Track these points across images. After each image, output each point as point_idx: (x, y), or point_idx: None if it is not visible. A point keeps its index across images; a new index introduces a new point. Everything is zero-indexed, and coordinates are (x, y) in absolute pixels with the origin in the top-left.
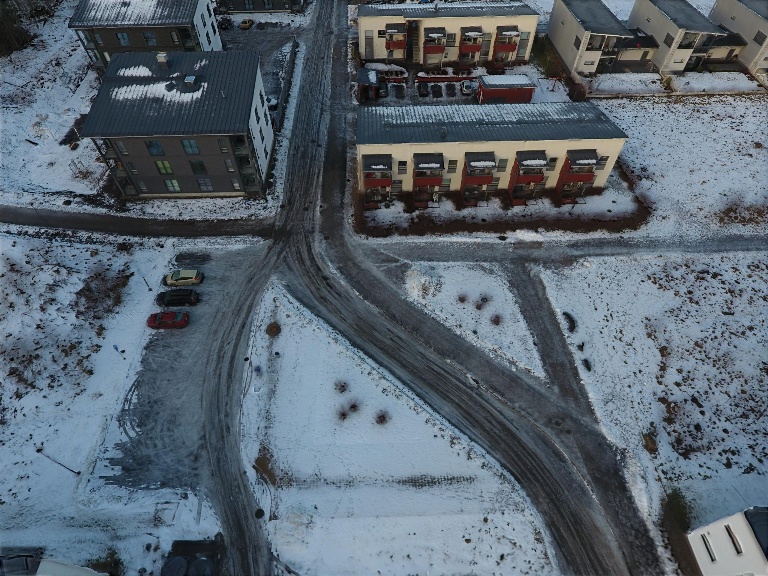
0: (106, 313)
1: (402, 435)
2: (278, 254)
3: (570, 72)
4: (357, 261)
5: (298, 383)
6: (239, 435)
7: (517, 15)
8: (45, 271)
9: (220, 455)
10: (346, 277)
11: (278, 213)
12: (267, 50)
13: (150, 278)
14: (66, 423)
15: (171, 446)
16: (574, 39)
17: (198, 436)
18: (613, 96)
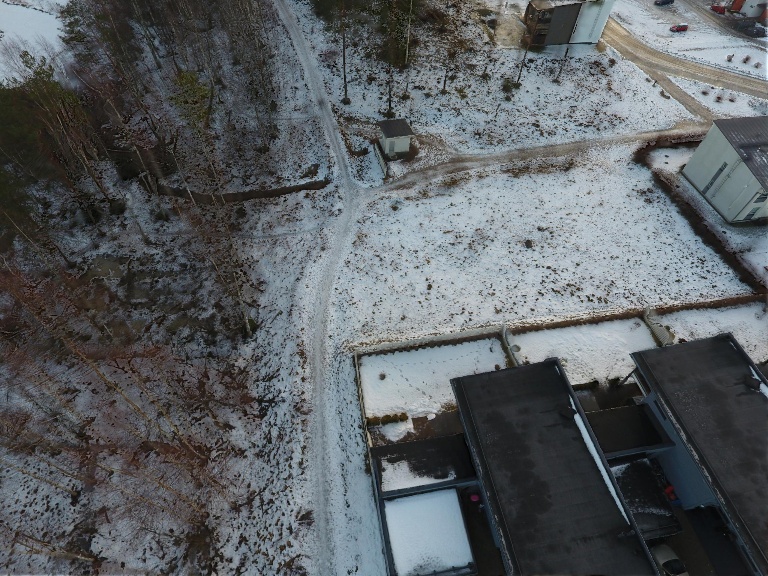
0: None
1: None
2: None
3: None
4: None
5: None
6: None
7: None
8: None
9: None
10: None
11: None
12: None
13: None
14: None
15: None
16: None
17: None
18: None
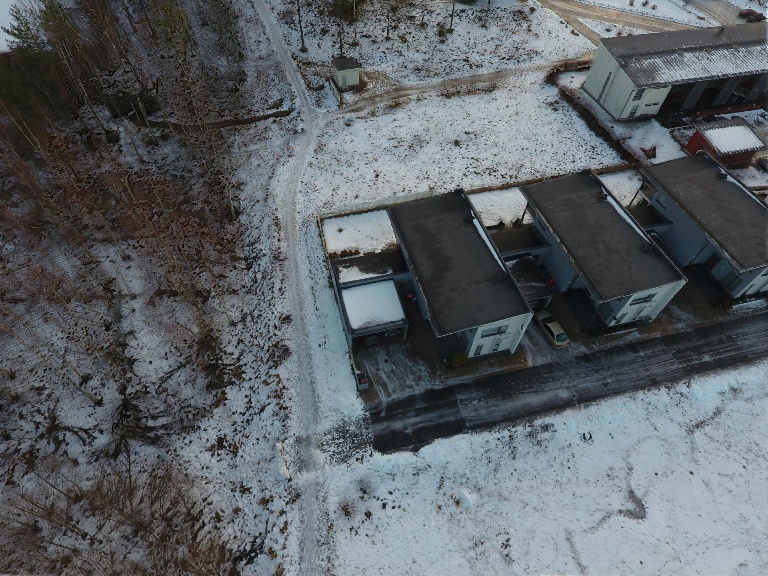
0: None
1: (621, 3)
2: None
3: None
4: None
5: None
6: None
7: None
8: None
9: None
10: None
11: None
12: None
13: None
14: None
15: None
16: None
17: None
18: (610, 169)
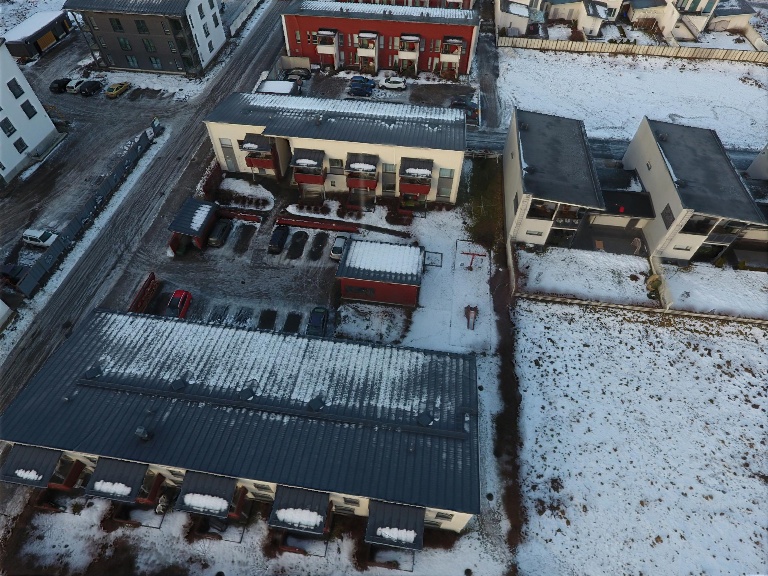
0: None
1: None
2: None
3: (506, 238)
4: None
5: None
6: None
7: (429, 147)
8: None
9: None
10: None
11: None
12: (116, 137)
13: None
14: None
15: None
16: (515, 193)
17: None
18: (557, 300)
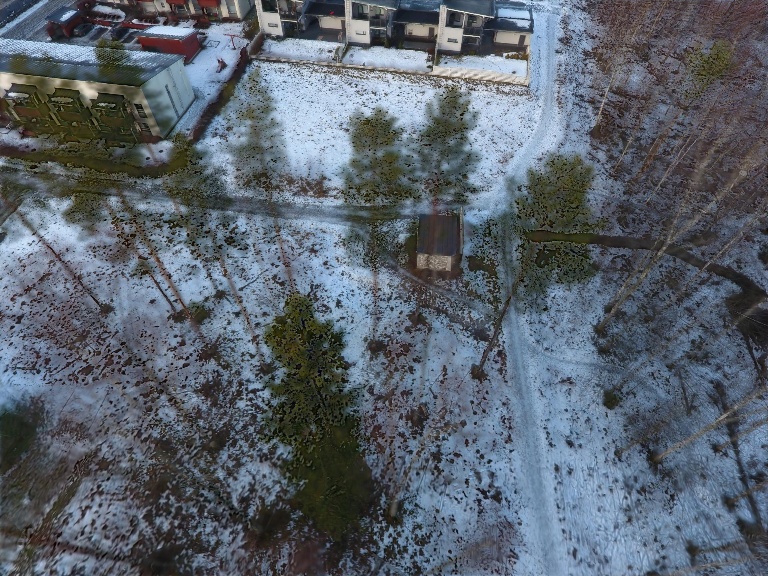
0: None
1: None
2: None
3: None
4: None
5: None
6: None
7: None
8: None
9: None
10: None
11: None
12: None
13: None
14: None
15: None
16: None
17: None
18: (275, 59)
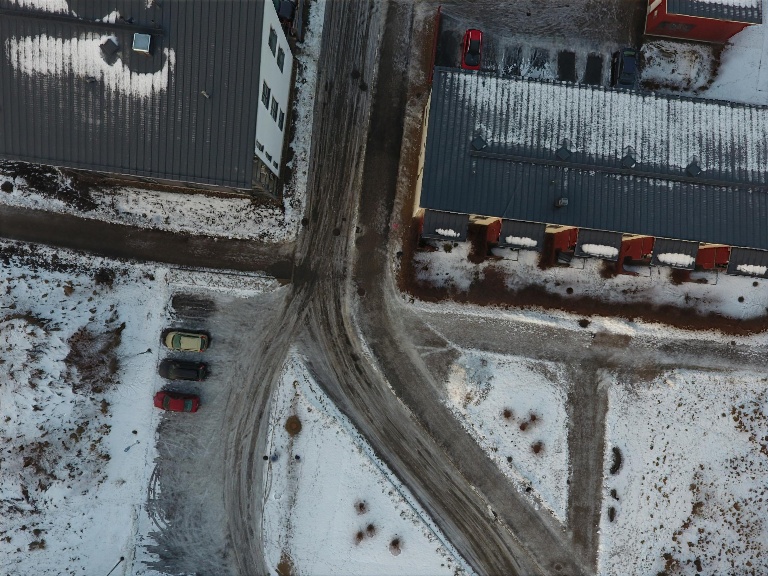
0: (105, 384)
1: (412, 560)
2: (299, 311)
3: None
4: (395, 338)
5: (318, 495)
6: (262, 541)
7: None
8: (17, 330)
9: (246, 556)
10: (379, 361)
11: (299, 235)
12: None
13: (146, 332)
14: (98, 511)
15: (200, 542)
16: None
17: (224, 536)
18: None
